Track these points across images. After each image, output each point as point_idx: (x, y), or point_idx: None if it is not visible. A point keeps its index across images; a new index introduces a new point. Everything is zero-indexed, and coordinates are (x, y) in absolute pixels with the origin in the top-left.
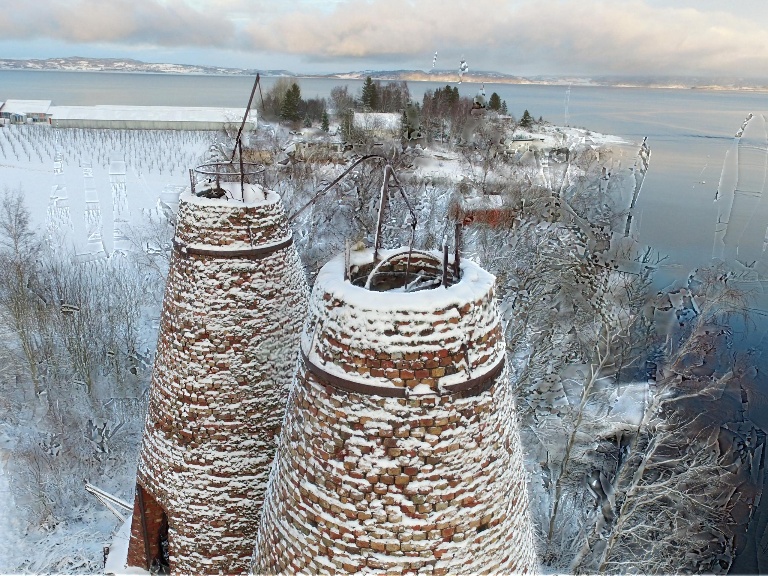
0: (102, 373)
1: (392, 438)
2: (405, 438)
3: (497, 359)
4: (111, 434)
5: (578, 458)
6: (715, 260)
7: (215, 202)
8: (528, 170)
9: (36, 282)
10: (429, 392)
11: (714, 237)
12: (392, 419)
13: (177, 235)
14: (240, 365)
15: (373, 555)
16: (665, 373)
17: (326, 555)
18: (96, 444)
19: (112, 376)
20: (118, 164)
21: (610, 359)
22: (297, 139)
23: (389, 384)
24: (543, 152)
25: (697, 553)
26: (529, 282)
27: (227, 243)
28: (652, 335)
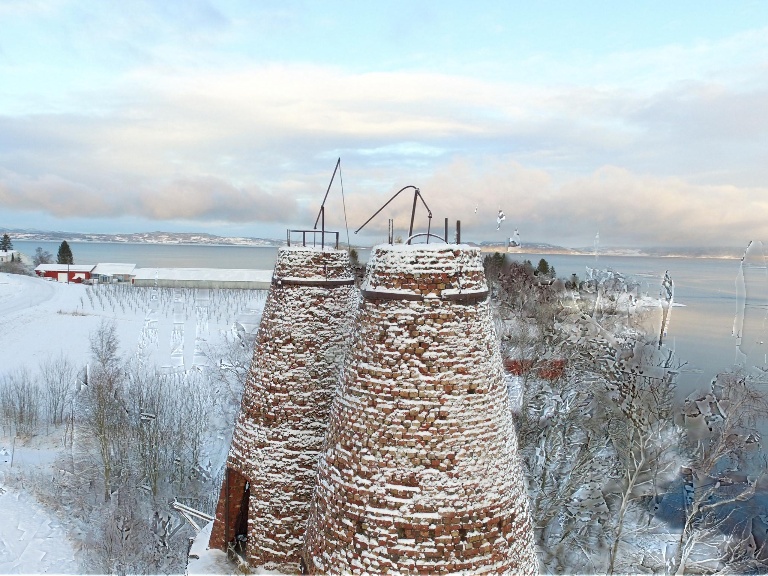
0: (168, 480)
1: (414, 325)
2: (422, 325)
3: (479, 290)
4: (171, 534)
5: (623, 571)
6: (734, 366)
7: (304, 249)
8: (559, 296)
9: (121, 393)
10: (436, 297)
11: (735, 351)
12: (414, 313)
13: (275, 274)
14: (313, 363)
15: (401, 400)
16: (702, 480)
17: (372, 406)
18: (159, 538)
19: (176, 484)
20: (204, 291)
21: (645, 465)
22: (356, 273)
23: (412, 293)
24: (575, 285)
25: None
26: (565, 395)
27: (310, 276)
28: (685, 441)
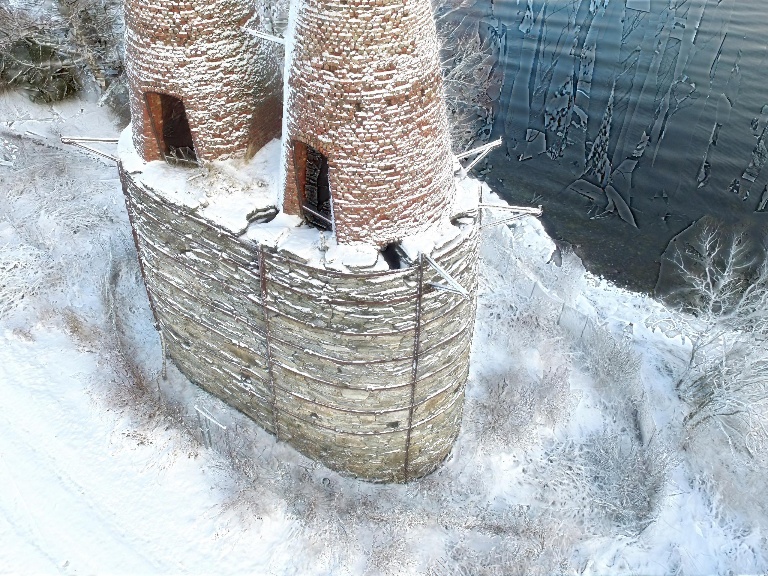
0: None
1: None
2: None
3: None
4: None
5: None
6: None
7: None
8: None
9: None
10: None
11: None
12: None
13: None
14: None
15: (378, 8)
16: None
17: (354, 17)
18: None
19: None
20: None
21: None
22: None
23: None
24: None
25: (470, 133)
26: None
27: None
28: None
